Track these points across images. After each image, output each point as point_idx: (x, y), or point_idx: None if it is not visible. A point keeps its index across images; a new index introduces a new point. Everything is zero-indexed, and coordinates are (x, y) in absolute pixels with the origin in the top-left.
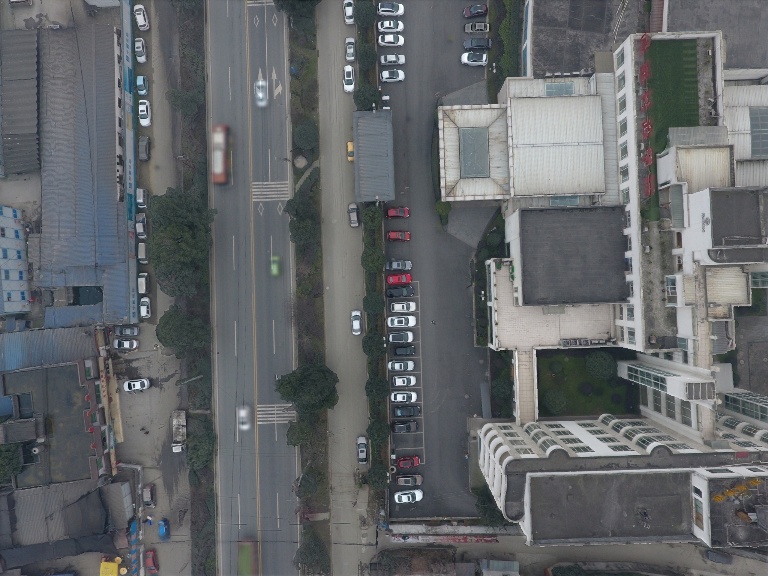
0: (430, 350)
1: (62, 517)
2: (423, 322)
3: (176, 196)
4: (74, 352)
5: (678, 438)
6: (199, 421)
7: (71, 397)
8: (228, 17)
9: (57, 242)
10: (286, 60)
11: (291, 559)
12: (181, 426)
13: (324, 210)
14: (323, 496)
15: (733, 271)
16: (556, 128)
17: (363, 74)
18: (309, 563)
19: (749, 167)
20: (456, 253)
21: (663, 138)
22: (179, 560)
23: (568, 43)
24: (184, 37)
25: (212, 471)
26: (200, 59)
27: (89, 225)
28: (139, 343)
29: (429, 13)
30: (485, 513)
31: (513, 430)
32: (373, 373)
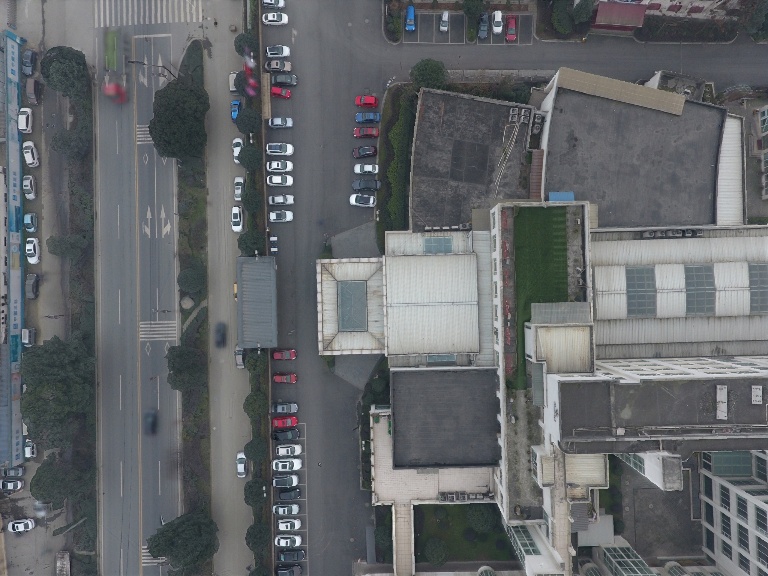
0: (316, 493)
1: None
2: (309, 464)
3: (47, 355)
4: None
5: None
6: (83, 563)
7: None
8: (118, 154)
9: None
10: (175, 199)
11: None
12: (64, 569)
13: (212, 350)
14: None
15: None
16: (431, 287)
17: (251, 214)
18: None
19: (628, 323)
20: (343, 395)
21: None
22: None
23: (450, 194)
24: (73, 175)
25: None
26: (88, 198)
27: None
28: (25, 483)
29: (319, 152)
30: None
31: None
32: (257, 517)
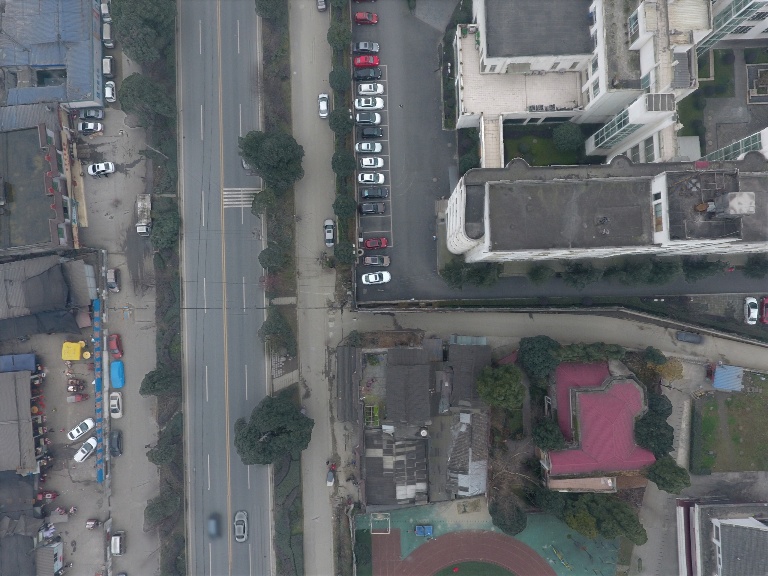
0: (398, 133)
1: (23, 291)
2: (391, 106)
3: None
4: None
5: None
6: None
7: (32, 161)
8: None
9: (20, 21)
10: None
11: None
12: None
13: None
14: (290, 280)
15: None
16: None
17: None
18: (273, 332)
19: None
20: (424, 37)
21: None
22: (144, 346)
23: None
24: None
25: (177, 255)
26: None
27: (53, 2)
28: (104, 127)
29: None
30: None
31: None
32: None
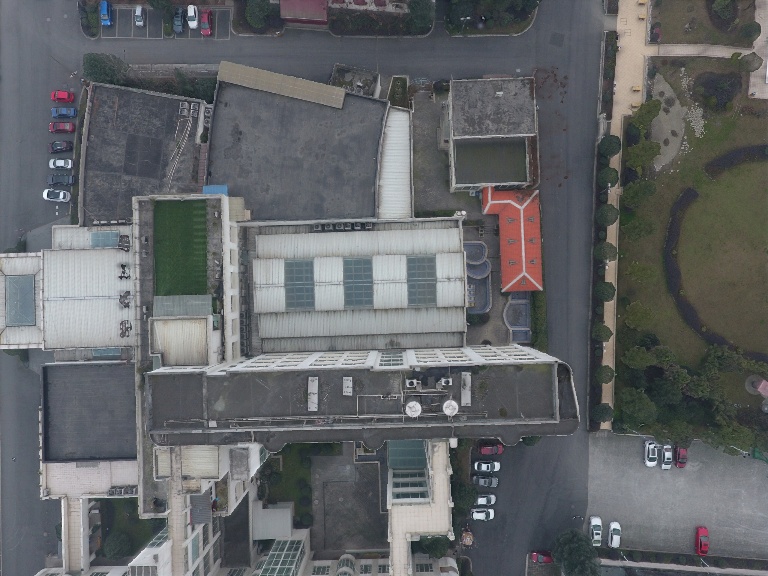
0: (10, 487)
1: None
2: (3, 459)
3: None
4: None
5: None
6: None
7: None
8: None
9: None
10: None
11: None
12: None
13: None
14: None
15: None
16: (88, 281)
17: None
18: None
19: (295, 316)
20: (38, 390)
21: None
22: None
23: (123, 188)
24: None
25: None
26: None
27: None
28: None
29: (16, 147)
30: None
31: None
32: None
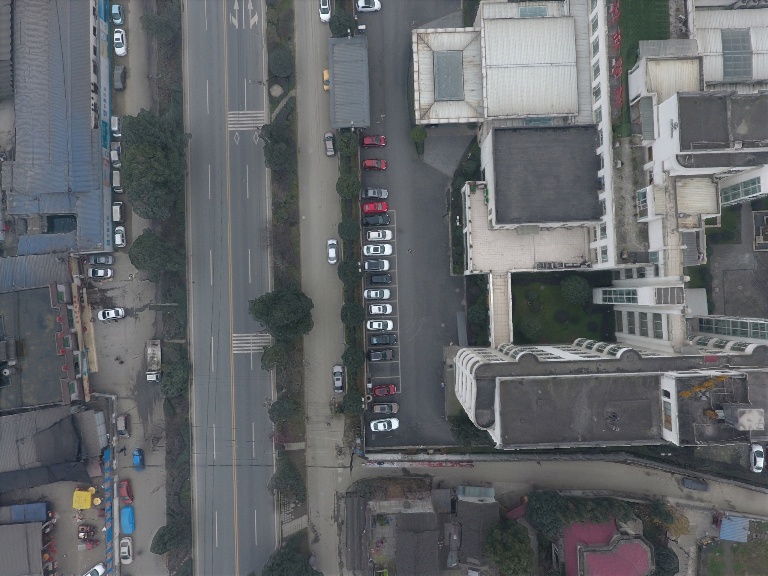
0: (406, 279)
1: (34, 444)
2: (399, 251)
3: (148, 115)
4: (47, 279)
5: (649, 351)
6: (174, 350)
7: (43, 320)
8: None
9: (31, 169)
10: None
11: (265, 485)
12: (156, 354)
13: (300, 140)
14: (299, 425)
15: (703, 181)
16: (529, 49)
17: (339, 3)
18: (283, 488)
19: None
20: (432, 182)
21: (635, 55)
22: None
23: None
24: None
25: (187, 401)
26: None
27: (63, 152)
28: (114, 272)
29: None
30: (459, 435)
31: (487, 351)
32: (349, 301)
